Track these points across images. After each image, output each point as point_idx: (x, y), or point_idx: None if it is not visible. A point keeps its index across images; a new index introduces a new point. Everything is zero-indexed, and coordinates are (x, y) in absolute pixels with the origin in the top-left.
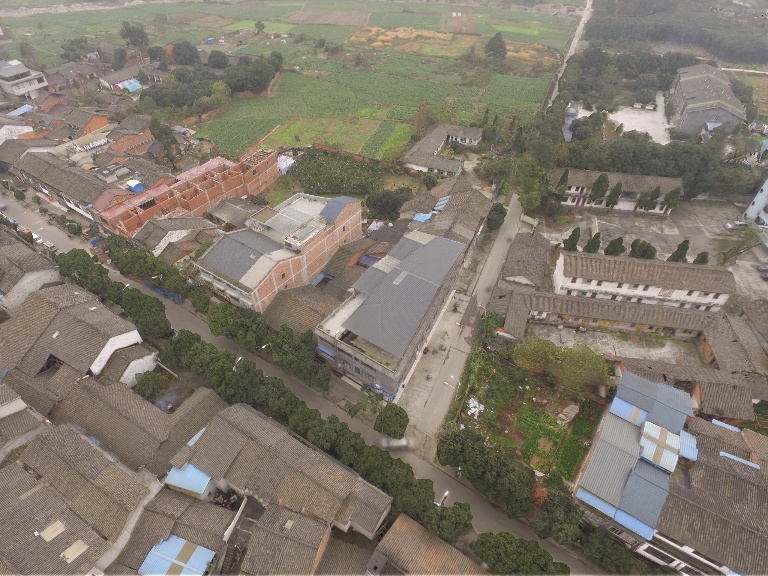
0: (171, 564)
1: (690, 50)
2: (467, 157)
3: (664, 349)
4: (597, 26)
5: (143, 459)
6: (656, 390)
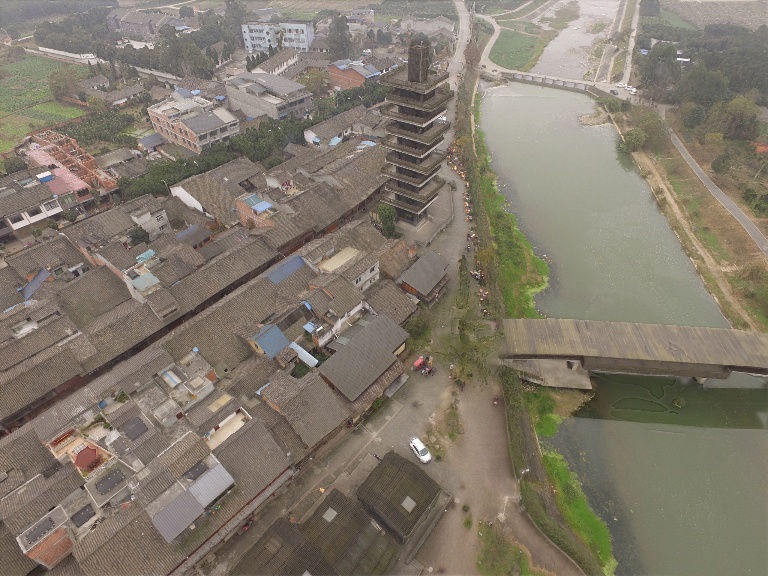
0: None
1: (61, 17)
2: None
3: None
4: None
5: None
6: None
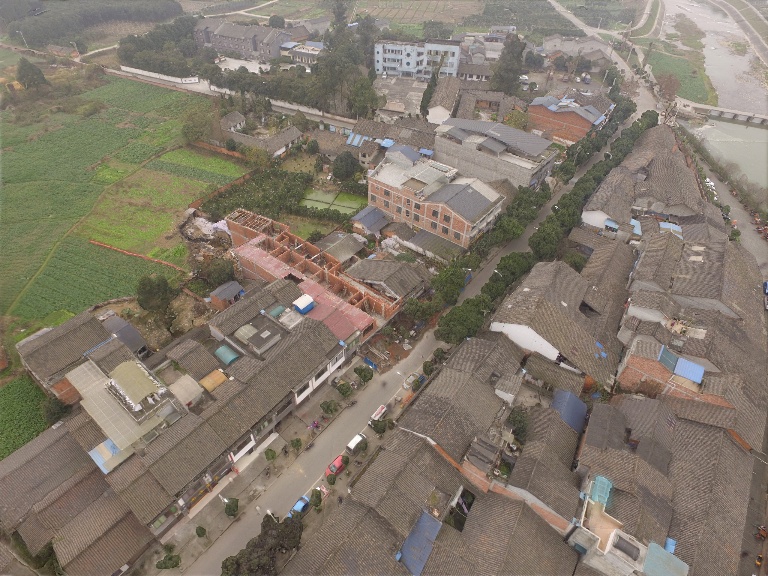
0: (674, 233)
1: (121, 24)
2: (261, 133)
3: (481, 114)
4: (36, 29)
5: (630, 251)
6: (540, 100)
